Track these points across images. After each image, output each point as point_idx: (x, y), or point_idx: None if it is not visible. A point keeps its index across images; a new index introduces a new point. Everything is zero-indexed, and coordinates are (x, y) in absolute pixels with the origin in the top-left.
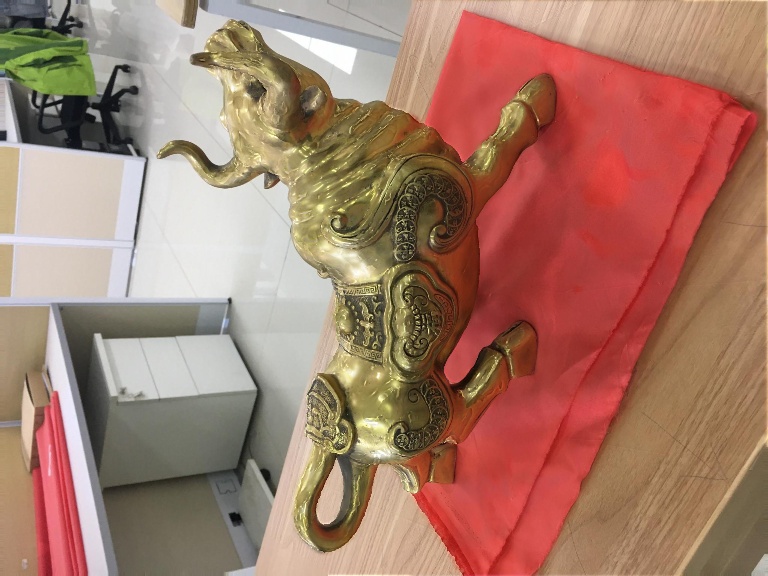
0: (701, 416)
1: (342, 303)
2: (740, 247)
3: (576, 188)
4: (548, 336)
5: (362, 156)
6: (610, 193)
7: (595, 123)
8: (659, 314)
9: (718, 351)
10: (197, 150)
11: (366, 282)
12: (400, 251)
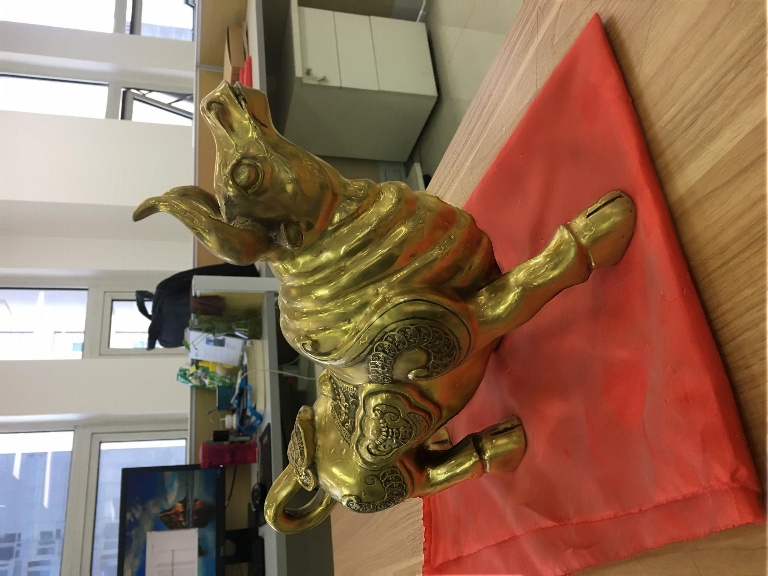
0: None
1: (327, 376)
2: None
3: (602, 363)
4: (533, 459)
5: (348, 285)
6: (626, 403)
7: (645, 320)
8: (602, 562)
9: None
10: (201, 196)
11: (344, 380)
12: (375, 377)
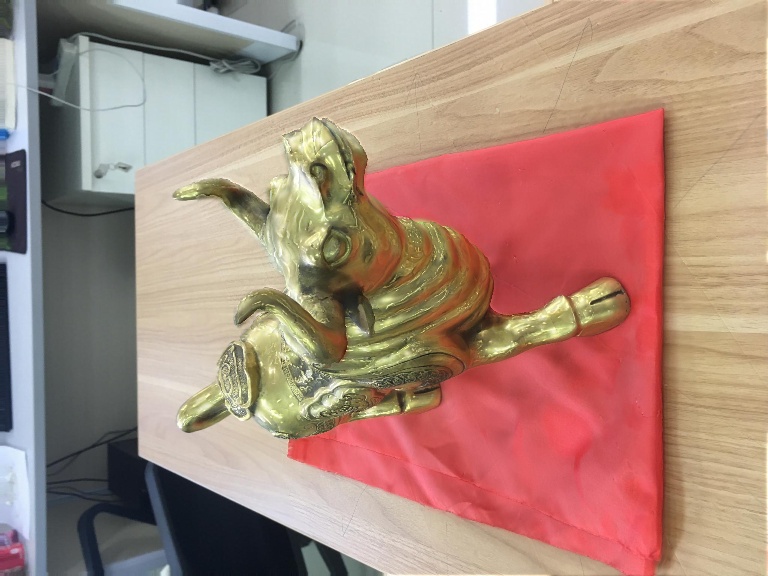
0: (467, 571)
1: None
2: (569, 575)
3: (548, 398)
4: (444, 417)
5: (382, 332)
6: (559, 436)
7: (605, 397)
8: None
9: (505, 574)
10: (225, 191)
11: None
12: None
